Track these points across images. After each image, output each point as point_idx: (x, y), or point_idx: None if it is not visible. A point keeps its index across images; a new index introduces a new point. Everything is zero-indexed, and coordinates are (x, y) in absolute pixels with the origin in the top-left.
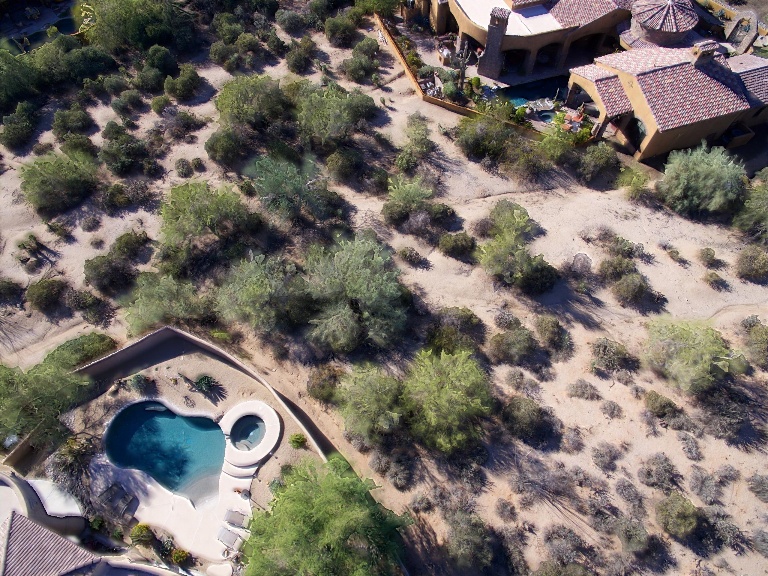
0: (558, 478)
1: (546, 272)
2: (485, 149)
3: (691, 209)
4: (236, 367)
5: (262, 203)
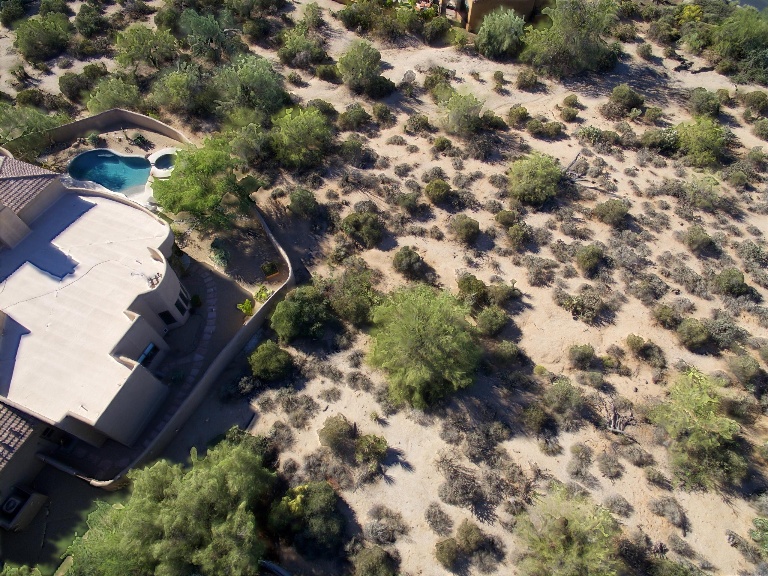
0: (368, 178)
1: (384, 80)
2: (358, 21)
3: (495, 53)
4: (164, 134)
5: (193, 51)
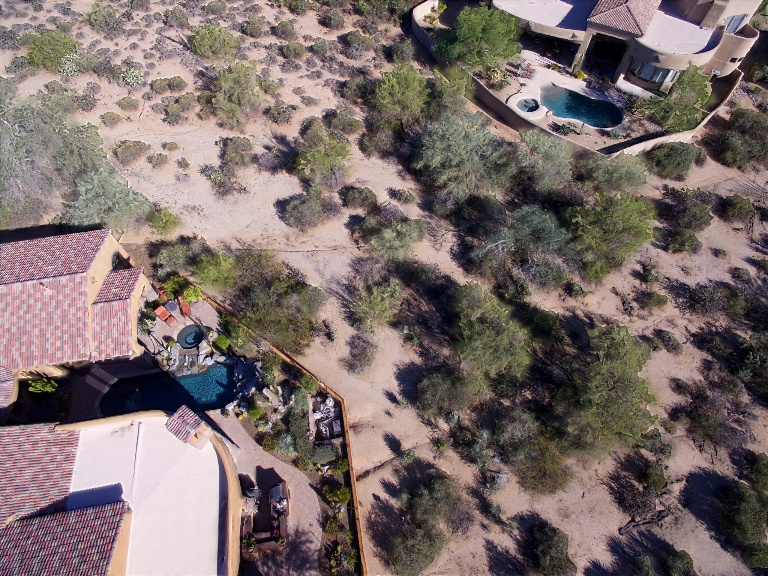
0: (347, 68)
1: None
2: None
3: None
4: None
5: None
